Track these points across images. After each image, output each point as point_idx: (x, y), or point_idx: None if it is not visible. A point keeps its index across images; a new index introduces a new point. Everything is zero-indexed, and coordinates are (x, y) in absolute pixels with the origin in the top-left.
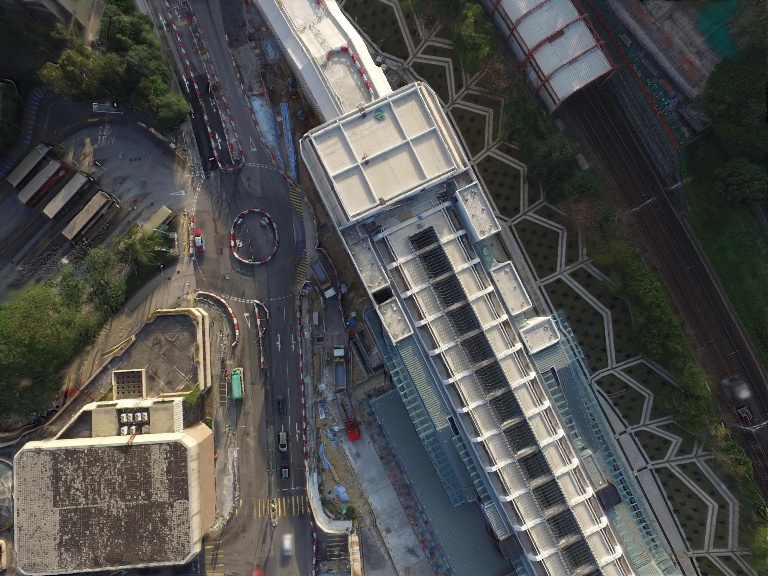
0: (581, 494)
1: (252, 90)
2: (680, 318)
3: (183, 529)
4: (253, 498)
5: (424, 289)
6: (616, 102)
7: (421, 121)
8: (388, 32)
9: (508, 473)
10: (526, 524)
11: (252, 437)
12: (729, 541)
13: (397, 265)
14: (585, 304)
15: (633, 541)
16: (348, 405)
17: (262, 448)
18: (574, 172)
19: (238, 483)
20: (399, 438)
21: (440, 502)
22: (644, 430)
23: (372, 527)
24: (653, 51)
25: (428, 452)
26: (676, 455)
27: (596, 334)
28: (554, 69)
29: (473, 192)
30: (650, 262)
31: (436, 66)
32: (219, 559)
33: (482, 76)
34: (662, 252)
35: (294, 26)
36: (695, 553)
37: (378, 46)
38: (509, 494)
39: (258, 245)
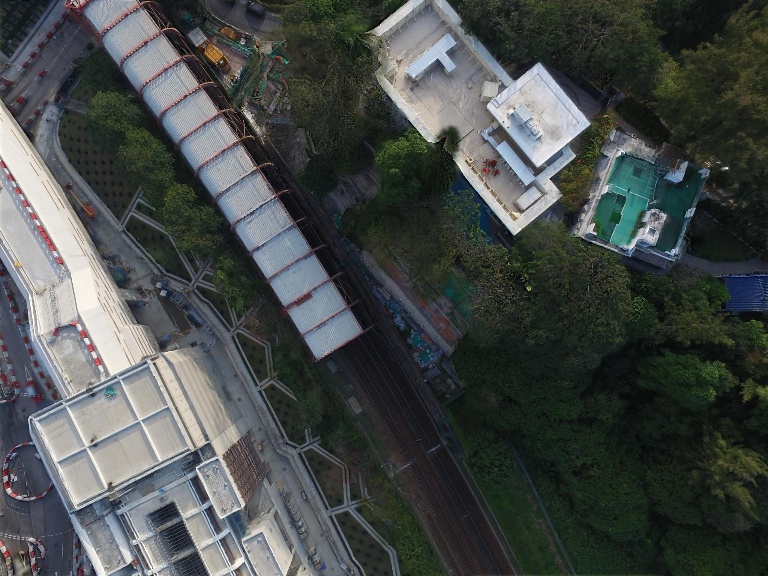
0: None
1: (27, 318)
2: (457, 569)
3: None
4: None
5: (166, 567)
6: (389, 343)
7: (155, 398)
8: (168, 257)
9: None
10: None
11: None
12: None
13: (137, 543)
14: (372, 540)
15: None
16: None
17: None
18: (334, 430)
19: None
20: None
21: None
22: None
23: None
24: (408, 310)
25: None
26: None
27: (385, 570)
28: (303, 332)
29: (215, 467)
30: (426, 510)
31: (216, 293)
32: None
33: (257, 311)
34: (437, 500)
35: (33, 289)
36: None
37: (162, 267)
38: None
39: (34, 479)
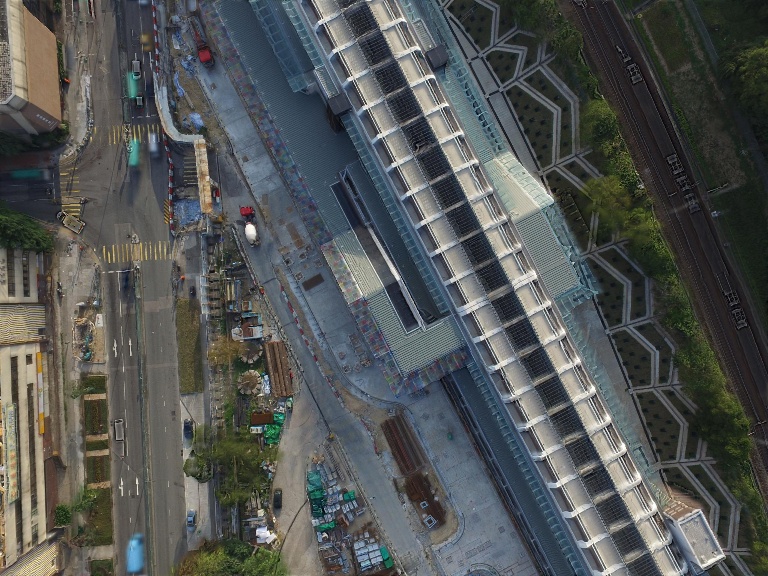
0: (407, 48)
1: None
2: None
3: (4, 71)
4: (107, 126)
5: None
6: None
7: None
8: None
9: (335, 27)
10: (352, 75)
11: (105, 65)
12: (572, 144)
13: None
14: None
15: (476, 138)
16: (199, 28)
17: (115, 76)
18: None
19: (92, 110)
20: (243, 39)
21: (285, 101)
22: (494, 51)
23: (229, 155)
24: None
25: (260, 22)
26: (523, 69)
27: None
28: None
29: None
30: None
31: None
32: (74, 185)
33: None
34: None
35: None
36: (545, 170)
37: None
38: (335, 46)
39: None
